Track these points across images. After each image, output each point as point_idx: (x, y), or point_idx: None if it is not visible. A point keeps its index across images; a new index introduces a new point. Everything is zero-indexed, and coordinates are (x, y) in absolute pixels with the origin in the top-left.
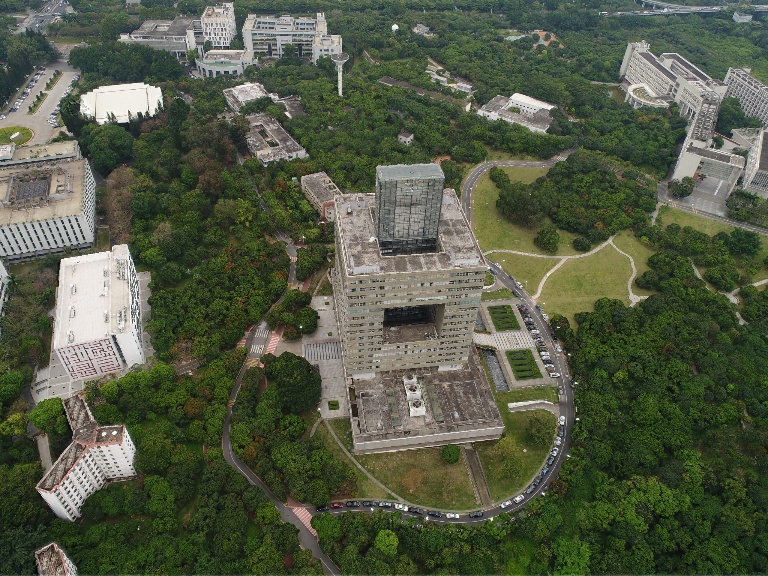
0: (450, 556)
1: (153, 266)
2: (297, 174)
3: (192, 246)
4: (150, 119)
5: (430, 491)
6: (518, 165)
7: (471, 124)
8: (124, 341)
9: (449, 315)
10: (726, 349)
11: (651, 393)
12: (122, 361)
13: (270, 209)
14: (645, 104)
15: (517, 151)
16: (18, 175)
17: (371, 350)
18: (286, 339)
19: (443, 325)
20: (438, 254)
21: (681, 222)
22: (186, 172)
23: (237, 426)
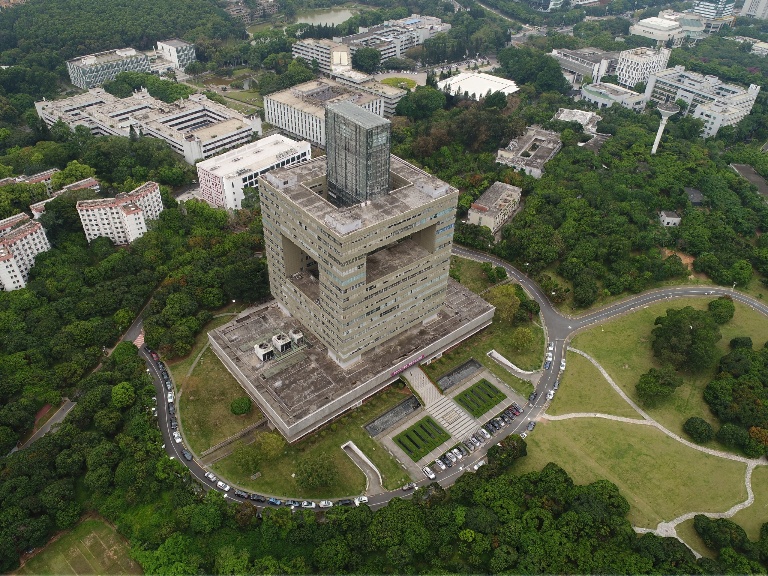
0: (127, 445)
1: None
2: (502, 180)
3: None
4: (472, 101)
5: (198, 411)
6: None
7: None
8: (227, 186)
9: (323, 282)
10: None
11: None
12: None
13: None
14: None
15: None
16: (335, 87)
17: (281, 278)
18: None
19: (321, 292)
20: (335, 208)
21: None
22: None
23: (188, 266)
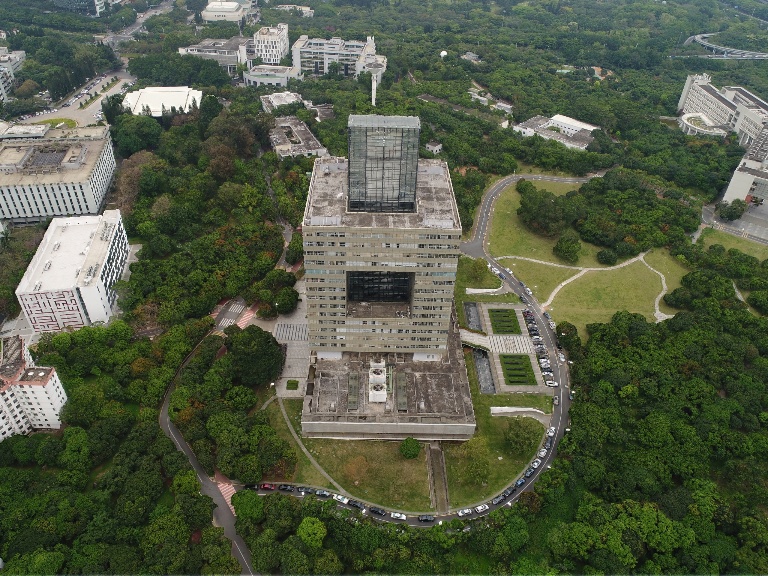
0: (383, 558)
1: (147, 238)
2: None
3: (188, 222)
4: (183, 114)
5: (378, 486)
6: (549, 179)
7: (504, 138)
8: (88, 296)
9: (421, 288)
10: (764, 375)
11: (663, 412)
12: (87, 319)
13: (276, 197)
14: (699, 131)
15: (550, 166)
16: (40, 146)
17: (334, 323)
18: (259, 316)
19: (415, 300)
20: (410, 215)
21: (727, 245)
22: (202, 159)
23: (178, 389)
